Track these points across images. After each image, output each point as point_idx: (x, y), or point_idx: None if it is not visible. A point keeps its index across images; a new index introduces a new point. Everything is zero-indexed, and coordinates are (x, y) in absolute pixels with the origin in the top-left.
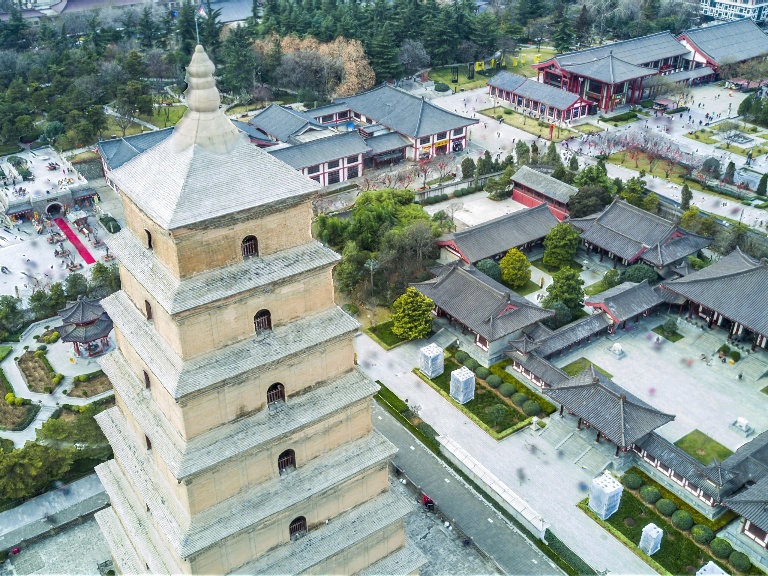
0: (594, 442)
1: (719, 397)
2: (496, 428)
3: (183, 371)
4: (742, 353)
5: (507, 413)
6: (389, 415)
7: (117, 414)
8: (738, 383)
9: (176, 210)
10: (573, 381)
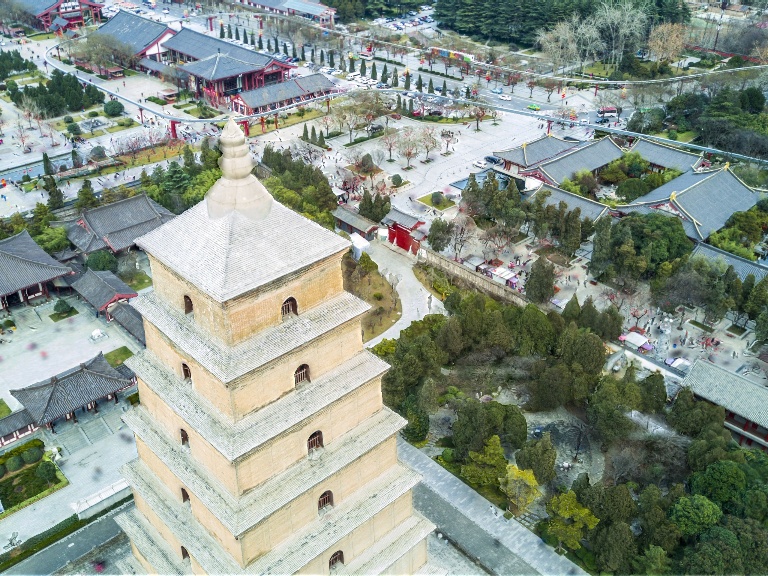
0: (96, 415)
1: (56, 343)
2: (51, 485)
3: (371, 355)
4: (8, 319)
5: (31, 476)
6: (8, 571)
7: (257, 567)
8: (42, 331)
9: (334, 234)
10: (33, 404)
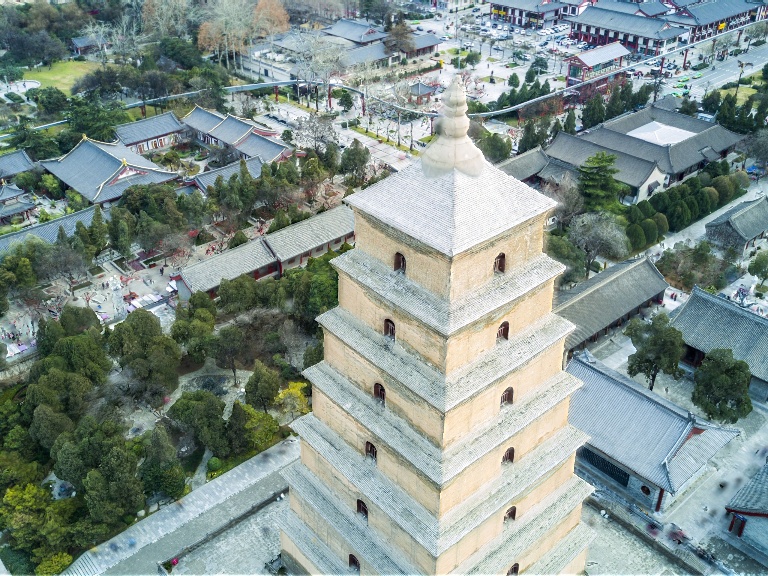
0: None
1: None
2: None
3: None
4: None
5: None
6: None
7: None
8: None
9: None
10: None
